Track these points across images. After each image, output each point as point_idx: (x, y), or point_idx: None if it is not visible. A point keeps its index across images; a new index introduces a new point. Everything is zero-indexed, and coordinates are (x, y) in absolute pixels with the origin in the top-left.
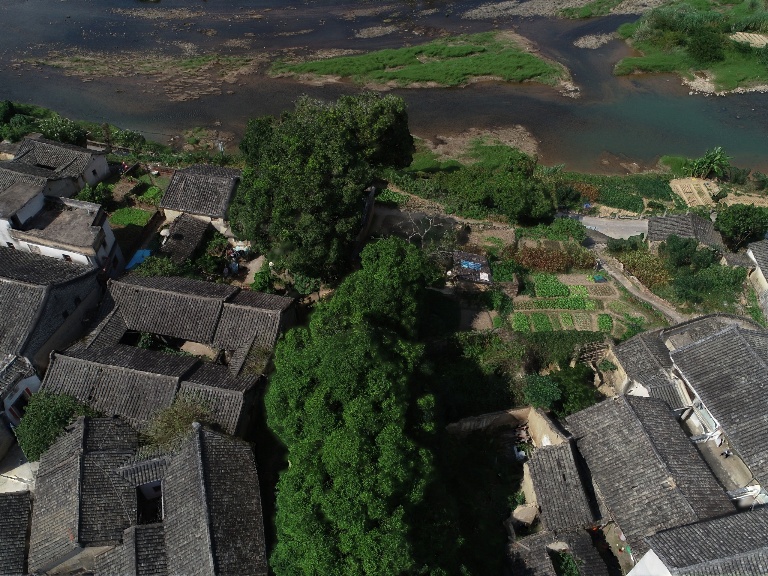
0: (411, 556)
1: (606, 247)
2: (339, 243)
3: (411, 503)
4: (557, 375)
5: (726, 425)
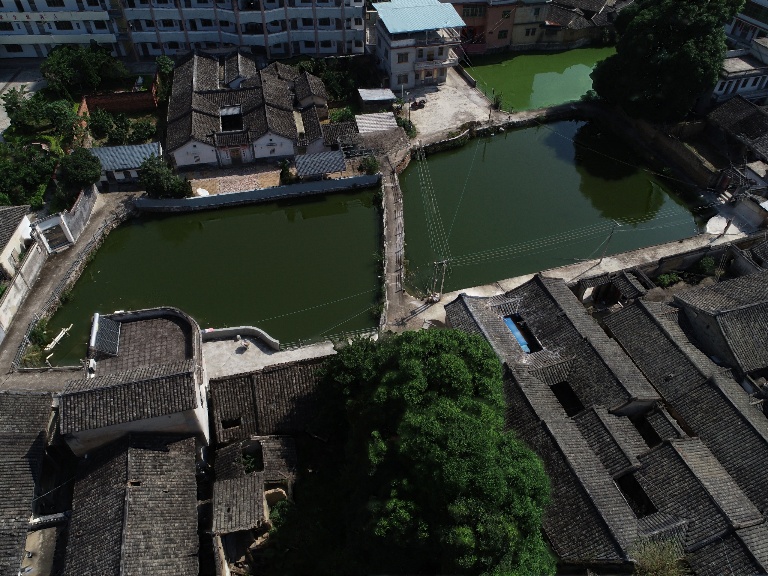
0: (391, 369)
1: None
2: None
3: None
4: None
5: (13, 568)
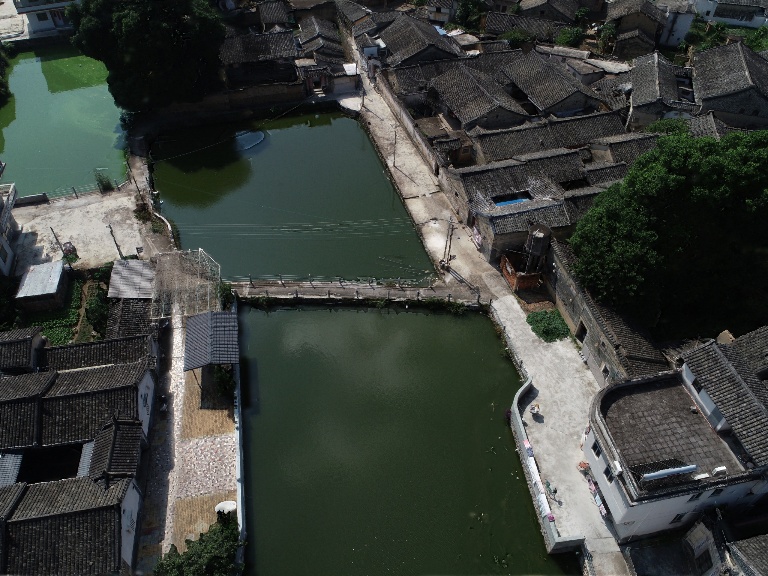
0: (659, 212)
1: None
2: None
3: (691, 195)
4: None
5: None
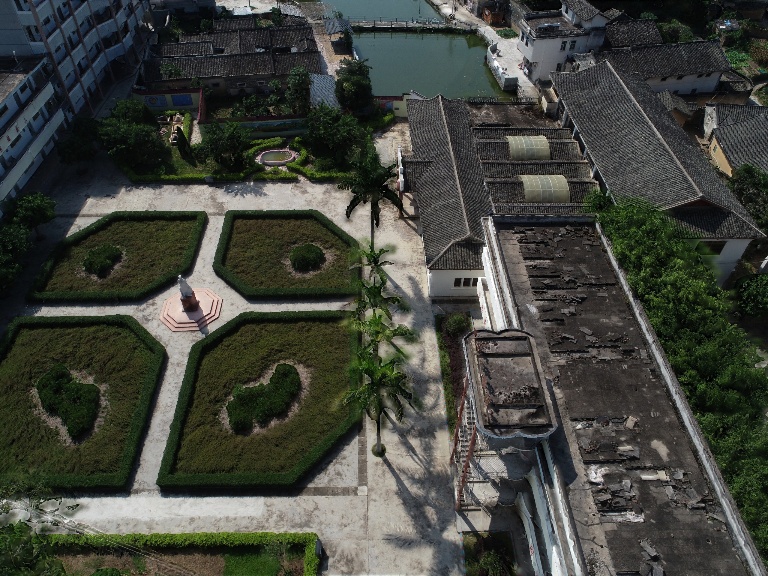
0: None
1: None
2: None
3: None
4: (665, 34)
5: None
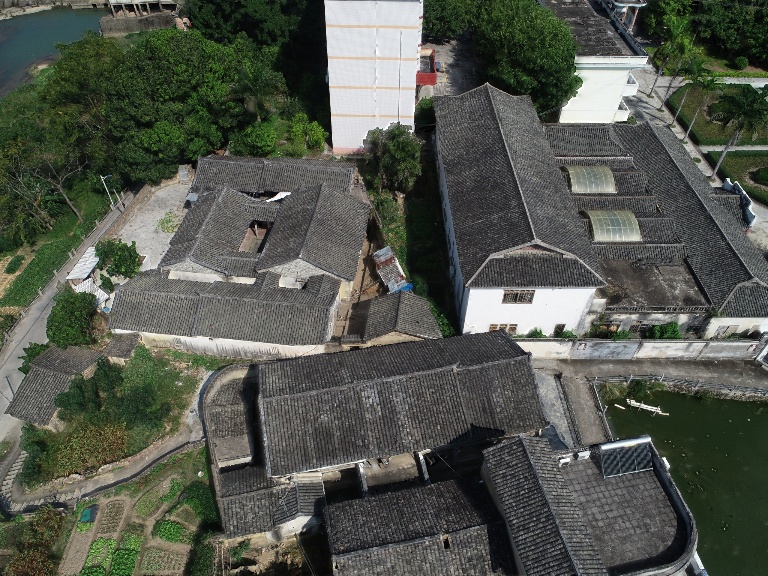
0: None
1: (21, 483)
2: None
3: None
4: None
5: (368, 454)
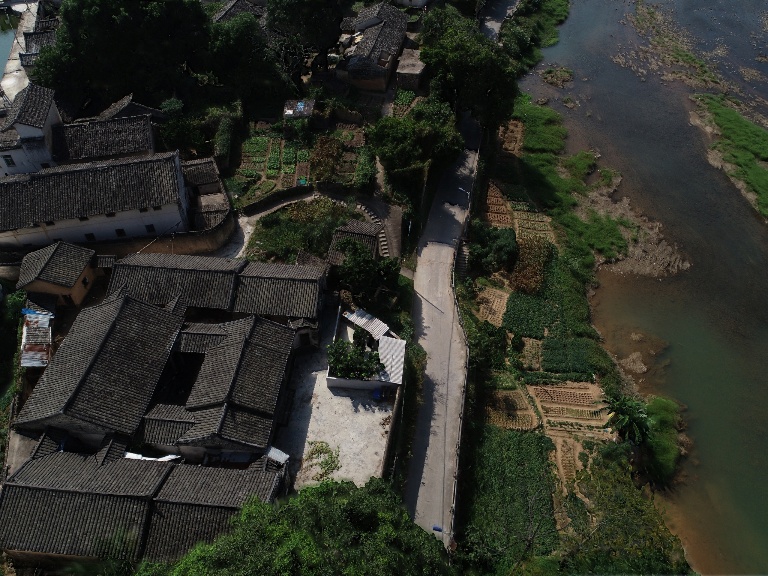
0: (74, 30)
1: None
2: (271, 20)
3: None
4: (194, 129)
5: None
